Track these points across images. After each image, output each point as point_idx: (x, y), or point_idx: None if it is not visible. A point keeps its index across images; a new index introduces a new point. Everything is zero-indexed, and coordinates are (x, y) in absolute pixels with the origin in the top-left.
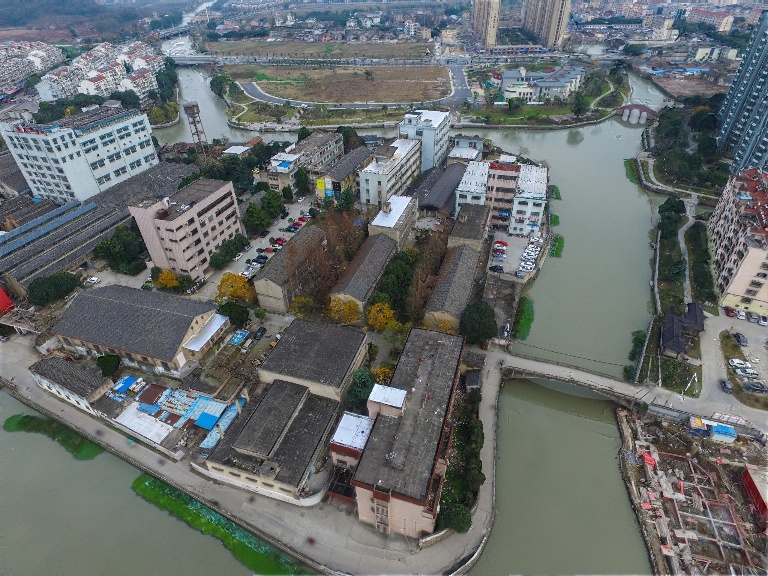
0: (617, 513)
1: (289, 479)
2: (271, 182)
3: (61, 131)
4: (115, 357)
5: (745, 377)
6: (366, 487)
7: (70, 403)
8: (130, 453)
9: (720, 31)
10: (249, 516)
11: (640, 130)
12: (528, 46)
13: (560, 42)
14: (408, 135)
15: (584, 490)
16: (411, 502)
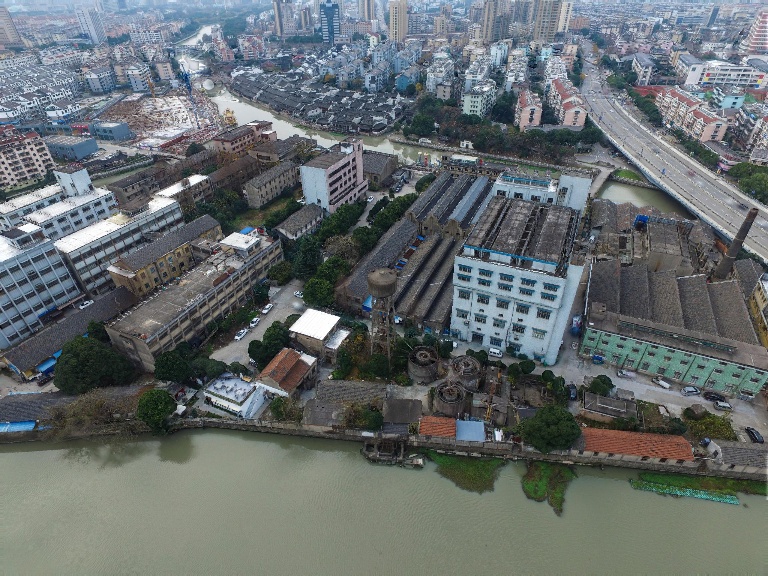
0: None
1: None
2: None
3: (498, 179)
4: None
5: (111, 157)
6: None
7: None
8: None
9: None
10: None
11: None
12: None
13: None
14: None
15: None
16: None
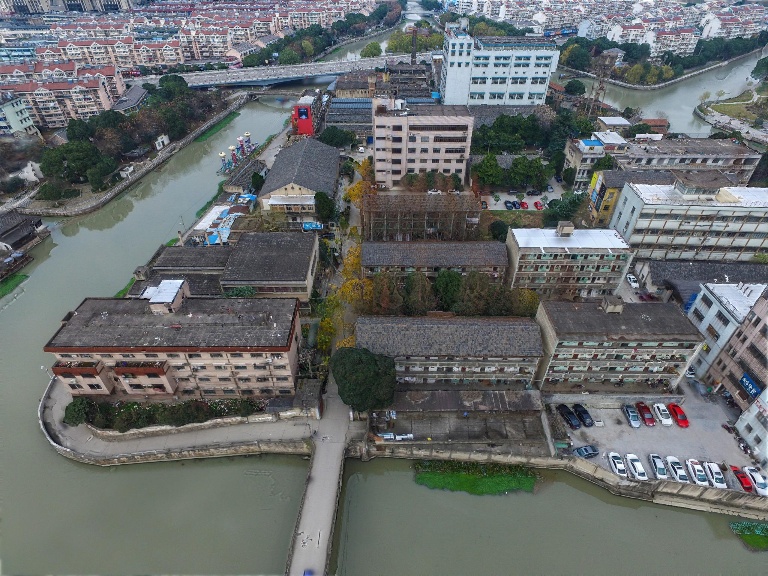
0: None
1: (137, 288)
2: (569, 157)
3: (464, 39)
4: (261, 179)
5: None
6: None
7: None
8: (195, 226)
9: None
10: None
11: None
12: None
13: None
14: None
15: None
16: None
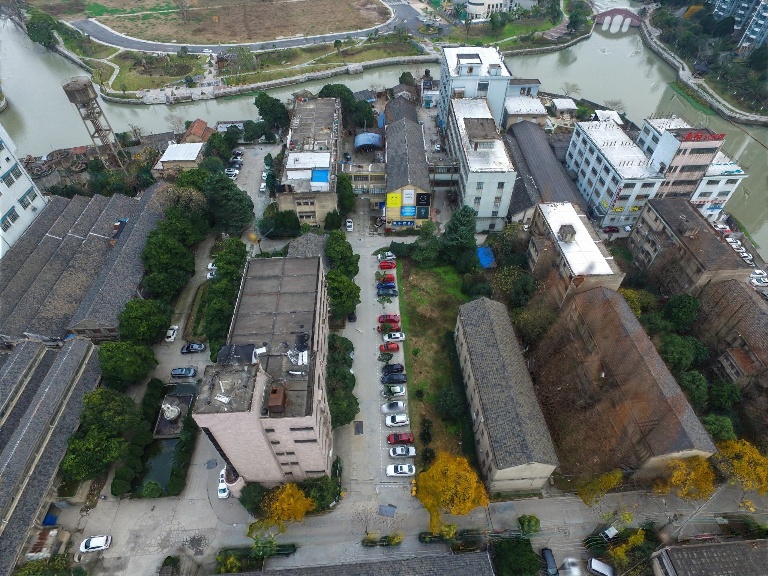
0: None
1: None
2: (299, 209)
3: None
4: None
5: None
6: None
7: None
8: None
9: None
10: None
11: (622, 40)
12: None
13: None
14: (465, 92)
15: None
16: None
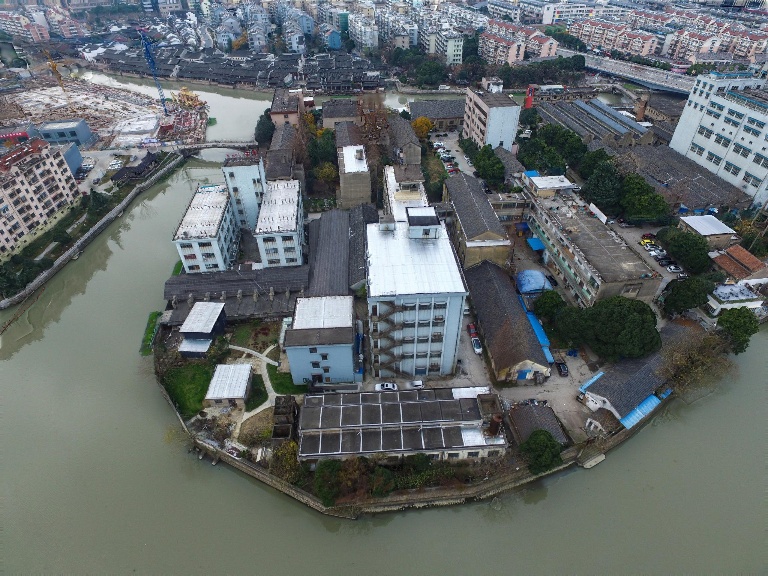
0: None
1: None
2: None
3: None
4: None
5: None
6: None
7: None
8: None
9: None
10: None
11: None
12: None
13: None
14: None
15: (222, 136)
16: None
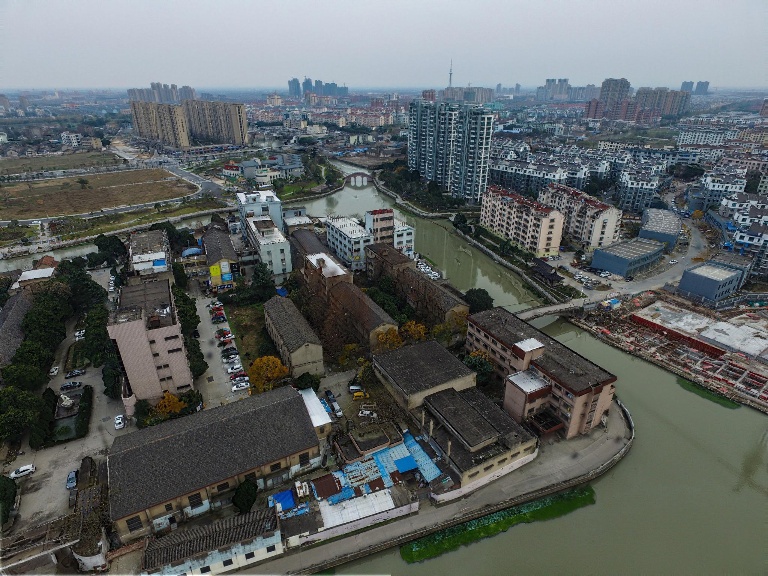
0: (626, 360)
1: (525, 438)
2: None
3: None
4: None
5: None
6: (587, 391)
7: (229, 571)
8: (370, 543)
9: (344, 126)
10: (517, 492)
11: (366, 190)
12: (220, 145)
13: (247, 140)
14: (254, 213)
15: (607, 359)
16: (610, 383)
